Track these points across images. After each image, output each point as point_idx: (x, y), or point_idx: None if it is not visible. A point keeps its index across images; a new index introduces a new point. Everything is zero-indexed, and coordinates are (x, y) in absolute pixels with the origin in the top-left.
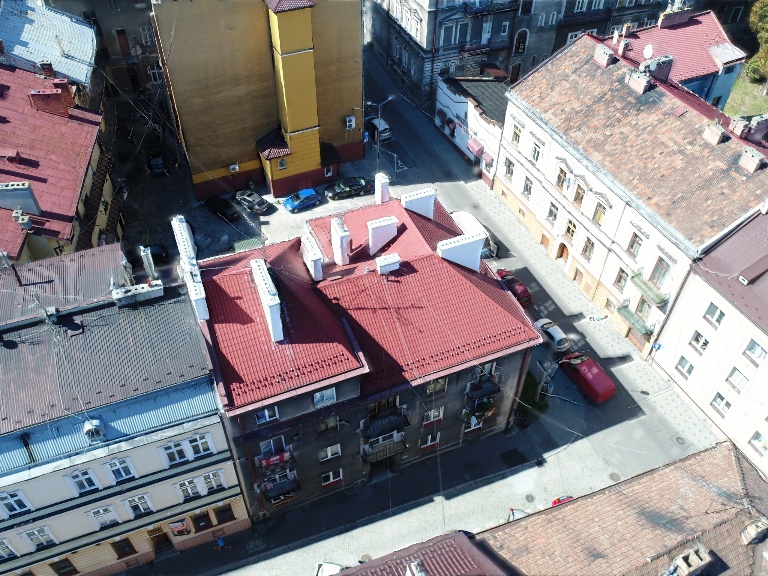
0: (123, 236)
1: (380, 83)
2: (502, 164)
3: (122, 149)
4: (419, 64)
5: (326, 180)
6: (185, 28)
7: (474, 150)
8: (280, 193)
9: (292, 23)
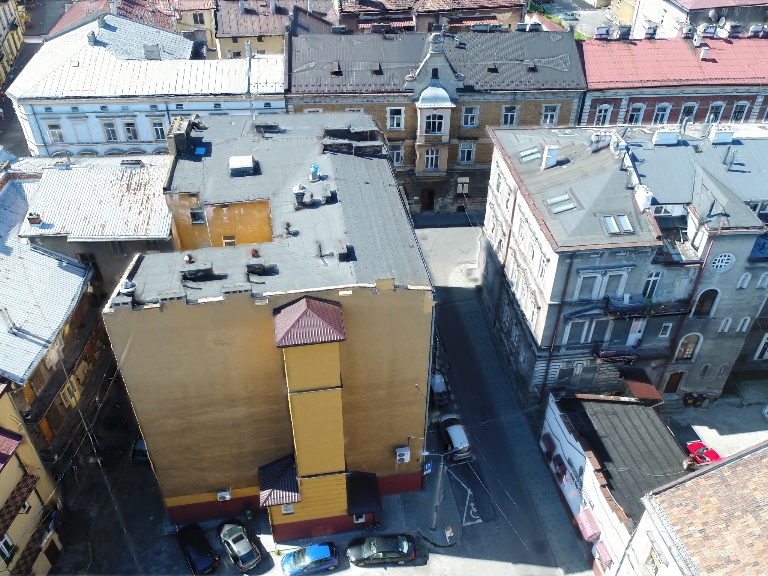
0: (51, 570)
1: (478, 353)
2: None
3: (116, 407)
4: (529, 357)
5: (355, 526)
6: (152, 341)
7: (585, 532)
8: (284, 537)
9: (308, 357)
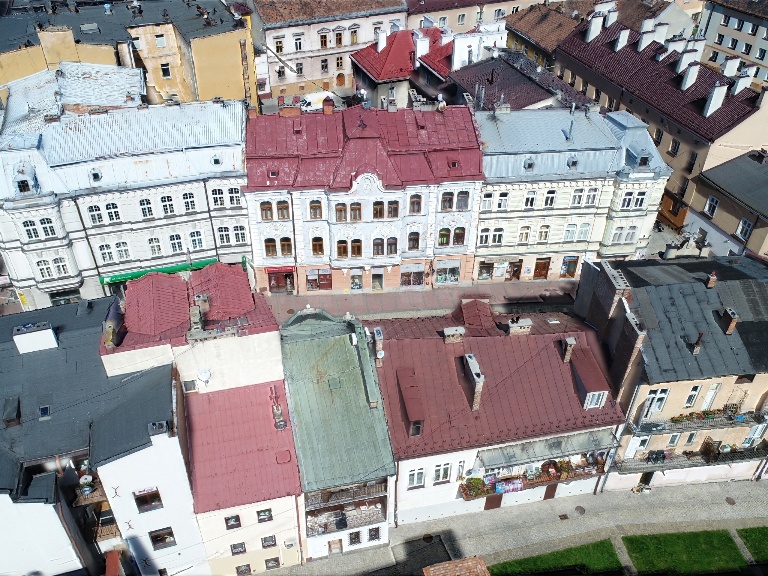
0: None
1: None
2: (274, 75)
3: None
4: None
5: None
6: None
7: None
8: None
9: None
